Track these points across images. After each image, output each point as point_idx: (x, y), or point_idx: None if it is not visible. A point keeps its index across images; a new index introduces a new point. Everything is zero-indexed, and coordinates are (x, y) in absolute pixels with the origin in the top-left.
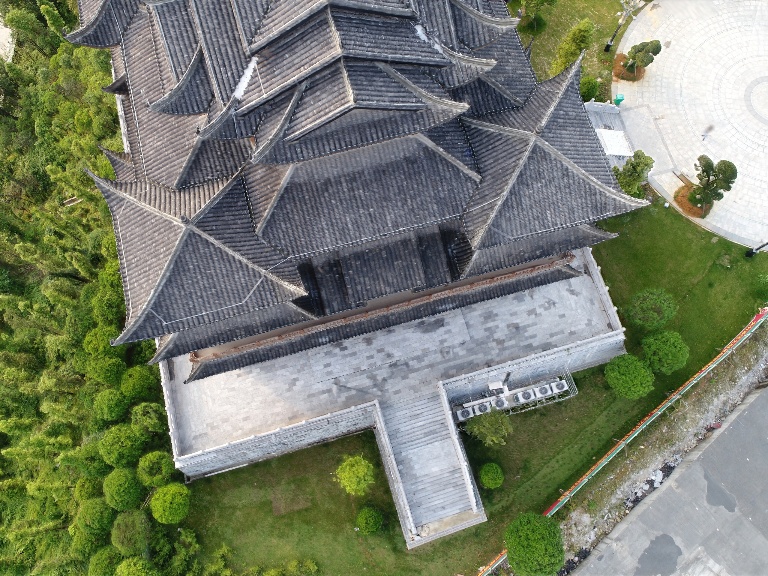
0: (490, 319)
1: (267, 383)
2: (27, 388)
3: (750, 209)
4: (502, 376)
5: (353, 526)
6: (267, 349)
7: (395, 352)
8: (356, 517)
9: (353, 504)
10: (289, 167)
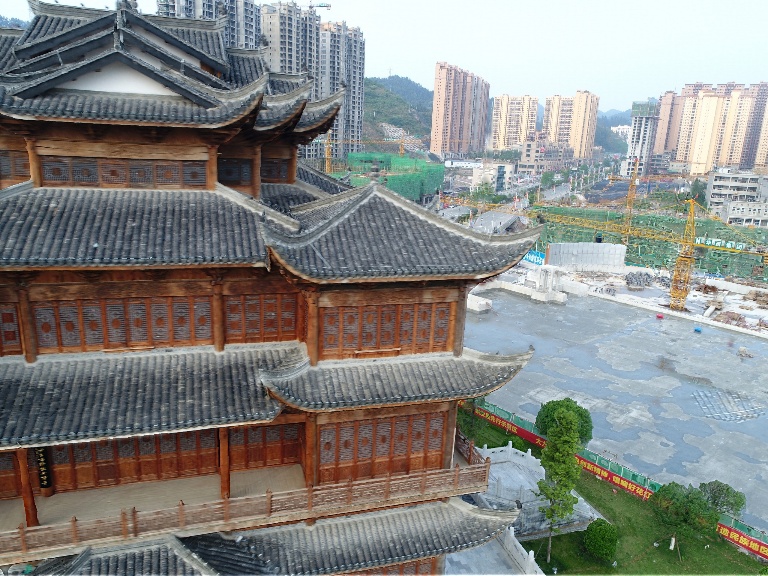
0: None
1: None
2: None
3: None
4: None
5: (613, 570)
6: None
7: None
8: (601, 565)
9: (587, 569)
10: (302, 182)
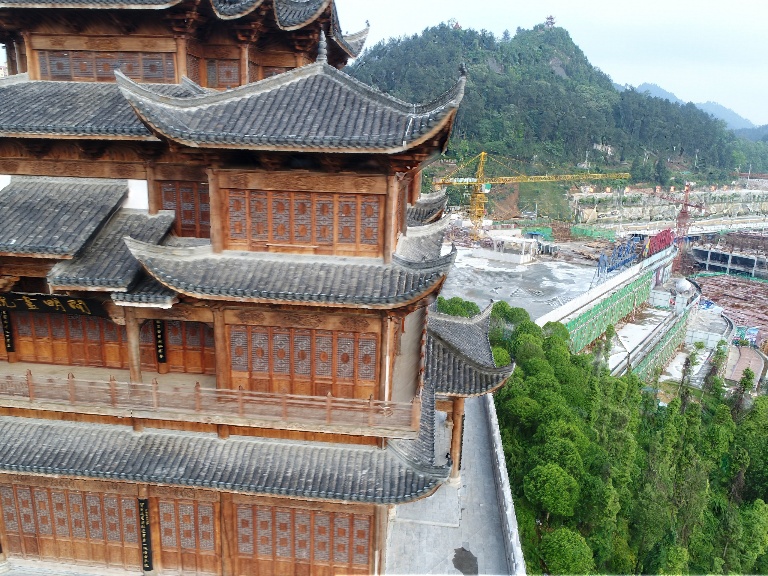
0: None
1: None
2: (655, 437)
3: None
4: None
5: None
6: None
7: None
8: None
9: None
10: None
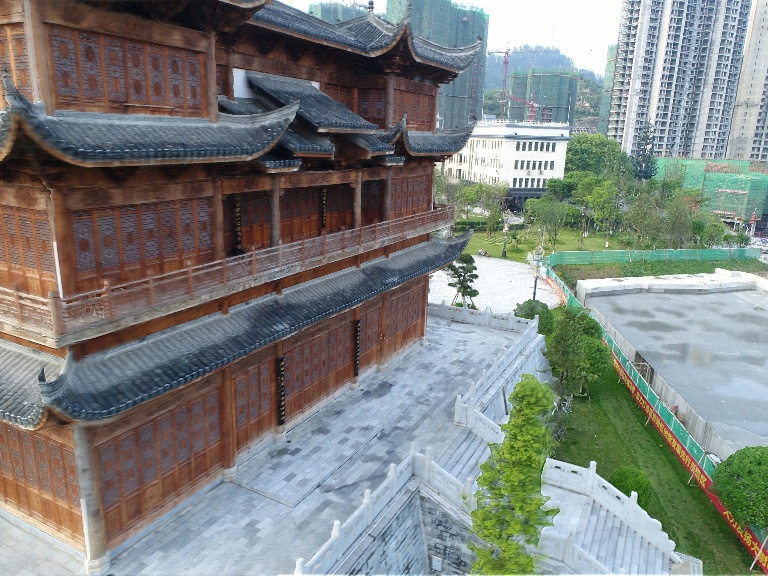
0: (429, 367)
1: (196, 559)
2: None
3: (499, 304)
4: (501, 403)
5: None
6: (194, 354)
7: (369, 423)
8: None
9: None
10: None
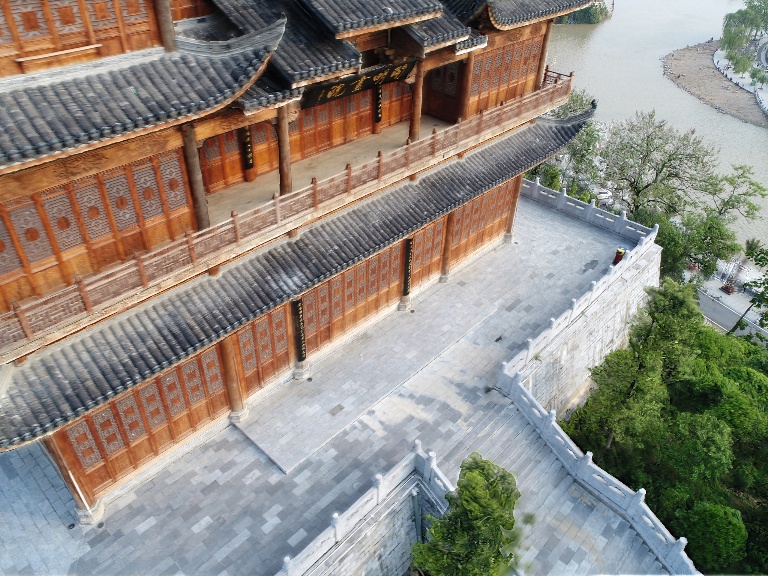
0: None
1: None
2: None
3: None
4: None
5: None
6: None
7: None
8: None
9: None
10: None
